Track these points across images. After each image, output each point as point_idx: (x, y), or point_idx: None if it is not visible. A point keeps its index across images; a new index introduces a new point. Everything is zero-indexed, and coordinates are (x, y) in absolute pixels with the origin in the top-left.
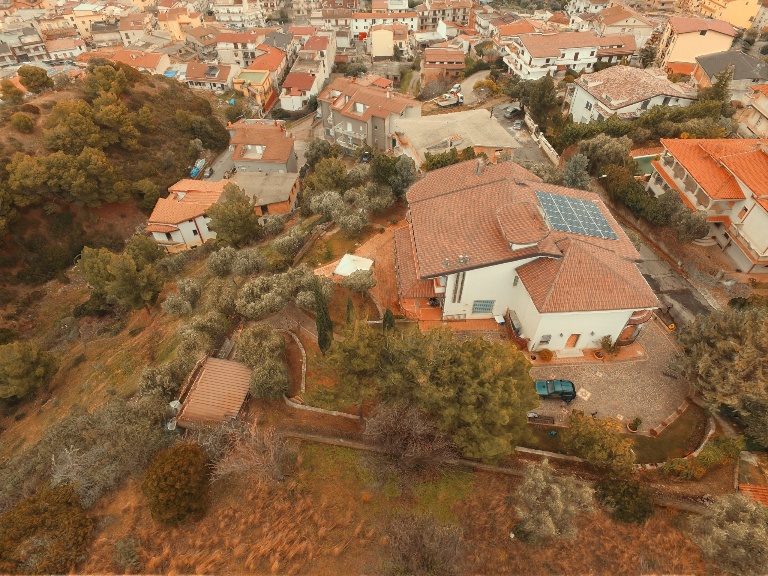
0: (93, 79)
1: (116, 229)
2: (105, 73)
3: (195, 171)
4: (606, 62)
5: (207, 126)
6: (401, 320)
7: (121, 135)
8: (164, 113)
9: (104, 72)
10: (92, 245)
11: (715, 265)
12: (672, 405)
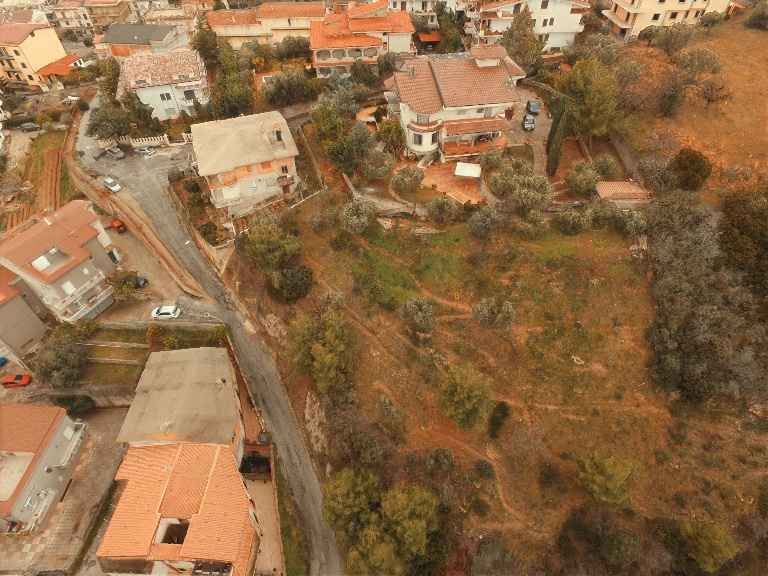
0: None
1: None
2: None
3: None
4: None
5: None
6: None
7: None
8: None
9: None
10: None
11: None
12: (519, 89)
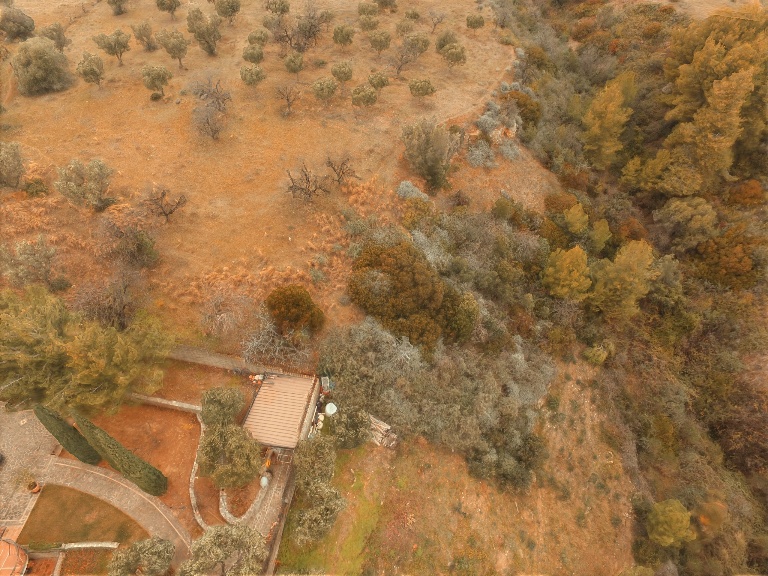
0: None
1: None
2: None
3: None
4: None
5: None
6: None
7: None
8: None
9: None
10: None
11: None
12: None
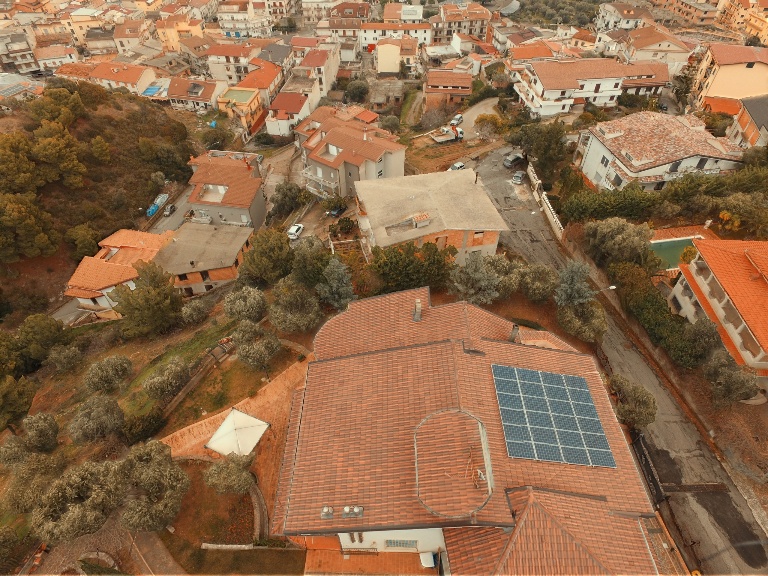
0: (40, 105)
1: (40, 286)
2: (57, 97)
3: (153, 209)
4: (632, 94)
5: (175, 155)
6: (280, 548)
7: (63, 171)
8: (128, 140)
9: (56, 96)
10: (8, 306)
11: (764, 441)
12: None
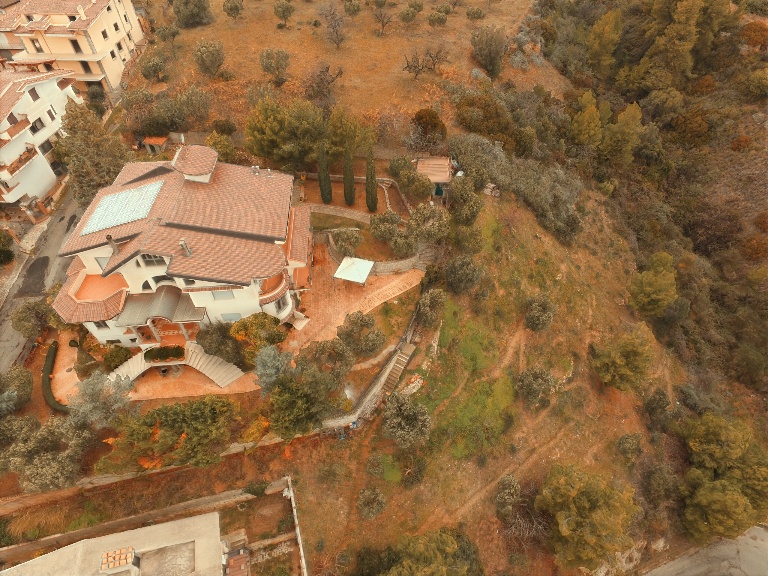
0: None
1: None
2: None
3: None
4: None
5: None
6: None
7: None
8: None
9: None
10: None
11: None
12: None
